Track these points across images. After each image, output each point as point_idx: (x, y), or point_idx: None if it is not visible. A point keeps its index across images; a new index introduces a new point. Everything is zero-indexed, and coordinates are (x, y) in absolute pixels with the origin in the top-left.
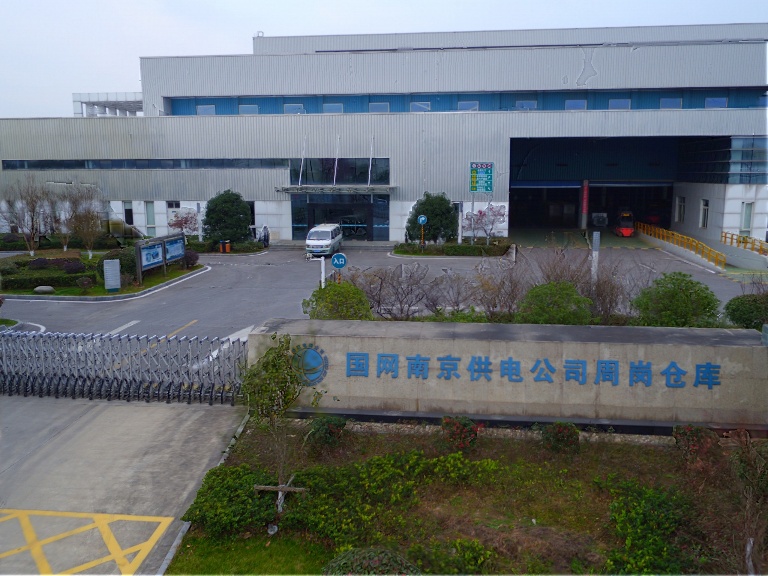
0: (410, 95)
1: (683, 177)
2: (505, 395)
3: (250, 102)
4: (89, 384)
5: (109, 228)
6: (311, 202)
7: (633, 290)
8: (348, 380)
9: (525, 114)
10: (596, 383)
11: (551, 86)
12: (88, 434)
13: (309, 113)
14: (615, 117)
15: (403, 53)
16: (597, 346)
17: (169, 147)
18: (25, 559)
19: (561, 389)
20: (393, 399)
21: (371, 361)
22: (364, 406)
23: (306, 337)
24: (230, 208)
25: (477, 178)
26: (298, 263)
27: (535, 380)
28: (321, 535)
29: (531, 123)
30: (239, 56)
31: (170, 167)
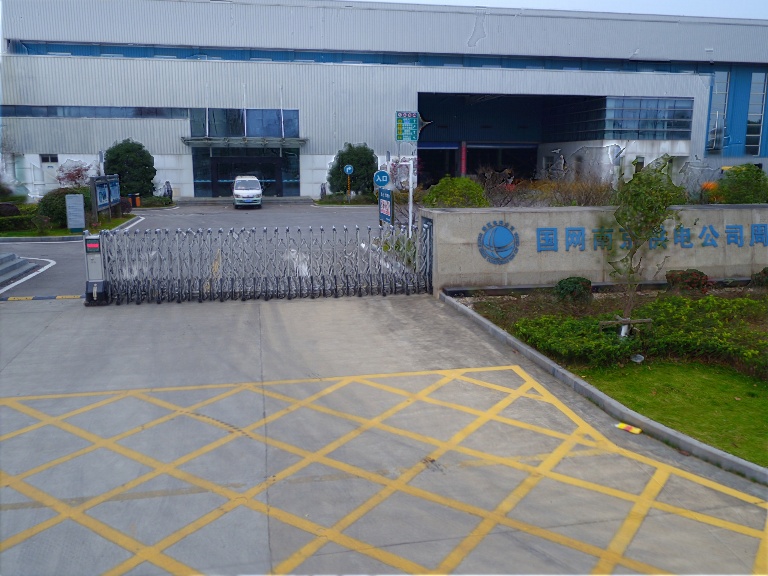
0: (293, 52)
1: (547, 139)
2: (679, 261)
3: (114, 51)
4: (233, 286)
5: (15, 173)
6: (215, 156)
7: (687, 188)
8: (539, 255)
9: (431, 69)
10: (751, 245)
11: (433, 49)
12: (297, 323)
13: (210, 59)
14: (511, 75)
15: (287, 7)
16: (750, 212)
17: (42, 92)
18: (431, 406)
19: (724, 252)
20: (582, 271)
21: (560, 235)
22: (554, 281)
23: (496, 214)
24: (135, 158)
25: (403, 127)
26: (233, 212)
27: (703, 245)
28: (697, 353)
29: (437, 78)
30: None
31: (44, 115)
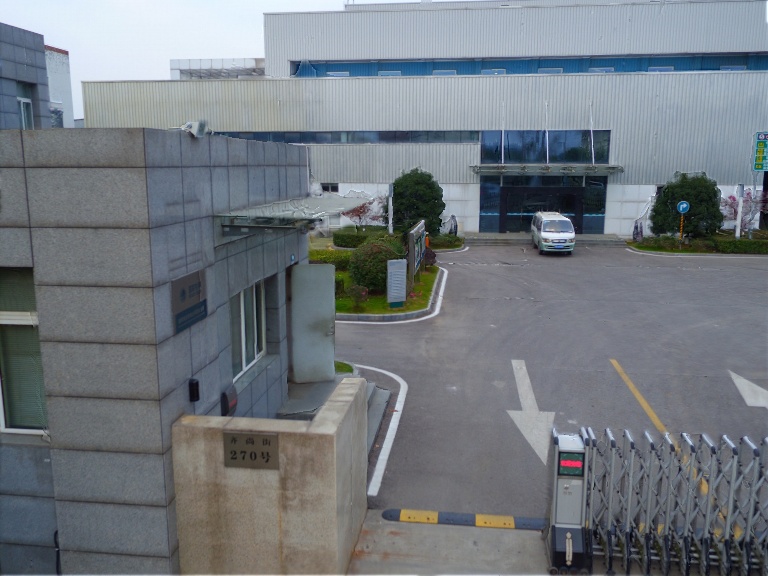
0: (589, 59)
1: None
2: None
3: (392, 68)
4: None
5: None
6: (506, 185)
7: None
8: None
9: None
10: None
11: None
12: None
13: (509, 73)
14: None
15: (588, 7)
16: None
17: (327, 116)
18: None
19: None
20: None
21: None
22: None
23: None
24: (425, 191)
25: (764, 153)
26: (544, 262)
27: None
28: None
29: None
30: (385, 11)
31: (327, 141)
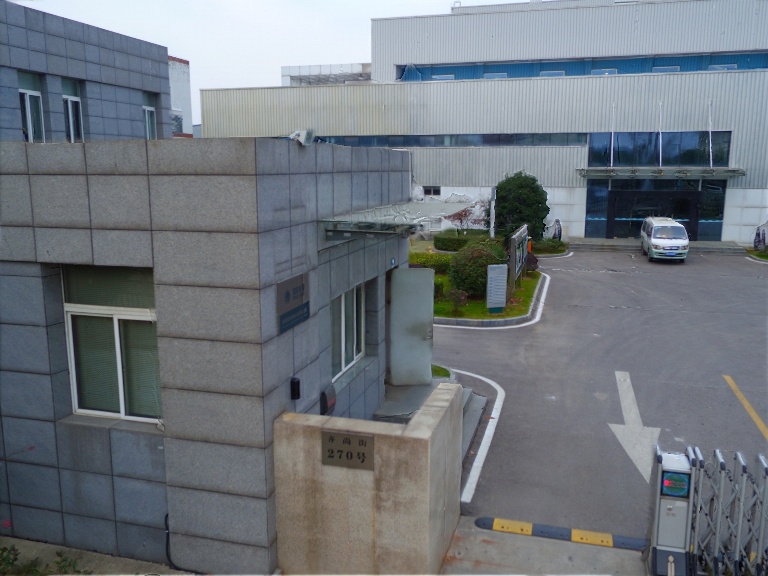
0: (709, 56)
1: None
2: None
3: (498, 70)
4: None
5: None
6: (614, 189)
7: None
8: None
9: None
10: None
11: None
12: None
13: (621, 73)
14: None
15: (710, 1)
16: None
17: (431, 120)
18: None
19: None
20: None
21: None
22: None
23: None
24: (528, 195)
25: None
26: (654, 270)
27: None
28: None
29: None
30: (492, 13)
31: (431, 145)
